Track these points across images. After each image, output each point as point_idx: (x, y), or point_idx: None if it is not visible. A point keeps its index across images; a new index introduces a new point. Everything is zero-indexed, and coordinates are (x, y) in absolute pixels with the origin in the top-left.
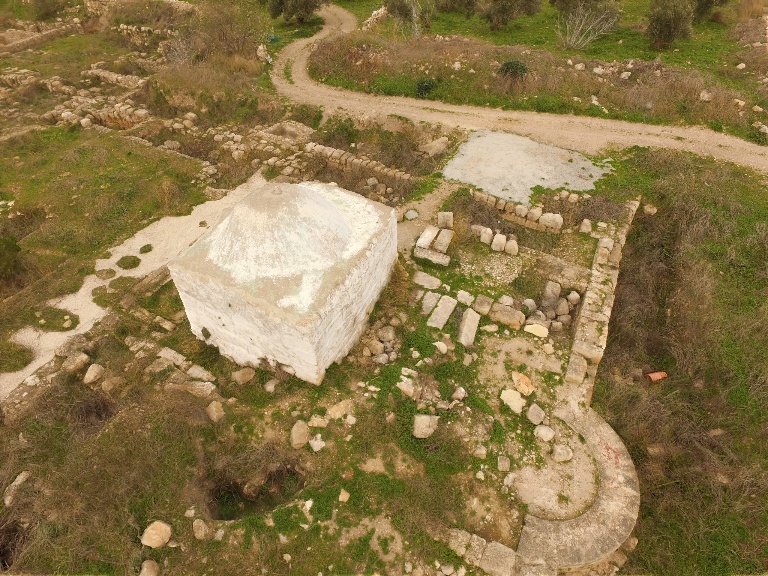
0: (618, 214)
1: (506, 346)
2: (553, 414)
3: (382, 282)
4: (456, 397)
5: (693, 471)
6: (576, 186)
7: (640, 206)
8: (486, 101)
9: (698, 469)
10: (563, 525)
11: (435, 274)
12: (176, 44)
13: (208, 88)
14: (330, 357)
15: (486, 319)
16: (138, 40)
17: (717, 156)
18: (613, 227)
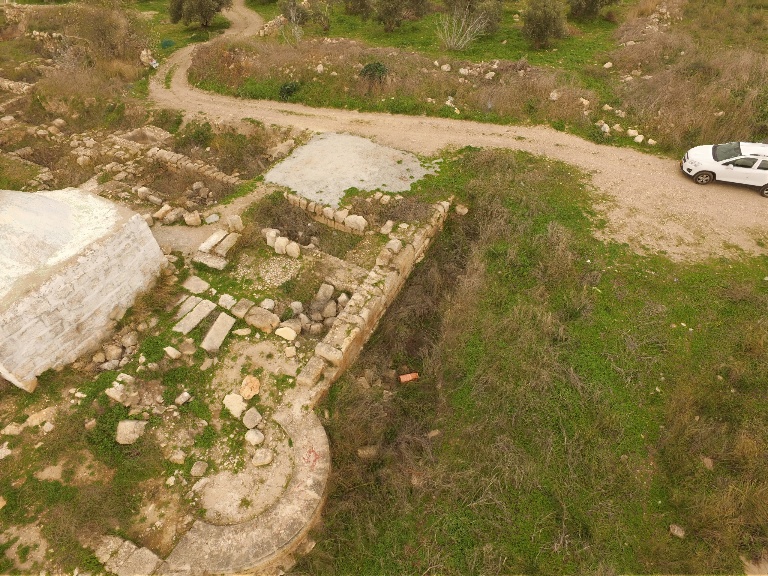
0: (421, 215)
1: (249, 350)
2: (272, 418)
3: (136, 287)
4: (176, 402)
5: (385, 473)
6: (392, 187)
7: (452, 207)
8: (344, 103)
9: (388, 471)
10: (227, 530)
11: (208, 278)
12: (62, 50)
13: (80, 94)
14: (40, 364)
15: (242, 323)
16: (51, 46)
17: (550, 155)
18: (413, 228)
